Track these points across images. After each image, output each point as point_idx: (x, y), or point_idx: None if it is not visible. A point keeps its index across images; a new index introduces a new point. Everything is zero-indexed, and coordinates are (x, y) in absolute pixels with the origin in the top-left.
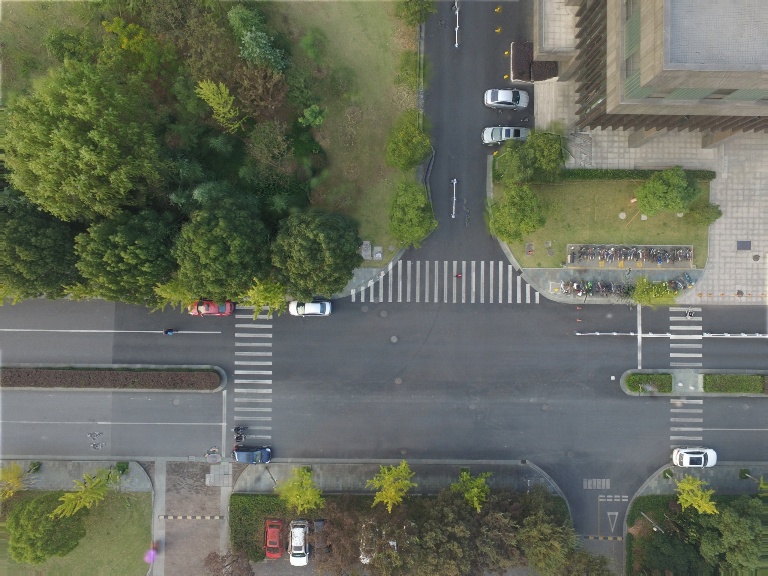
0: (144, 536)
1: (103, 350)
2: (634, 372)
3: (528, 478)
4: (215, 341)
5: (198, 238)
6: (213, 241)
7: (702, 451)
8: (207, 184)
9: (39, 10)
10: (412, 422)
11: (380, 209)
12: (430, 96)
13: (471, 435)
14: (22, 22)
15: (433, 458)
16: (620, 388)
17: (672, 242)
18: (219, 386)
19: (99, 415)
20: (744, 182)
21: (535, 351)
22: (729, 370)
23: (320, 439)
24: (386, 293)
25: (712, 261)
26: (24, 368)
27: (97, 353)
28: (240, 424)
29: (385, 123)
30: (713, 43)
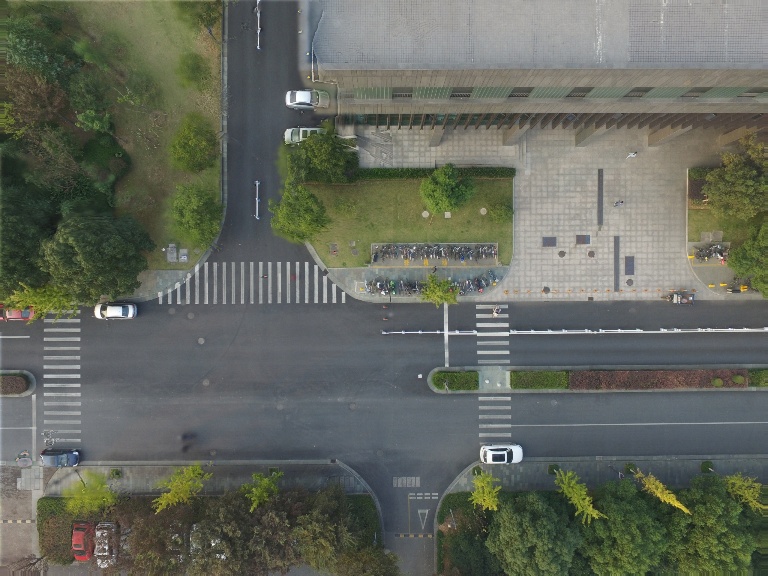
0: None
1: None
2: (440, 370)
3: (333, 477)
4: (23, 346)
5: None
6: None
7: (505, 448)
8: None
9: None
10: (221, 423)
11: None
12: (234, 98)
13: (280, 435)
14: None
15: (242, 459)
16: (428, 386)
17: (477, 240)
18: (26, 390)
19: None
20: (547, 178)
21: (342, 351)
22: (534, 367)
23: (130, 442)
24: (193, 295)
25: (518, 258)
26: None
27: None
28: (50, 428)
29: None
30: (353, 42)
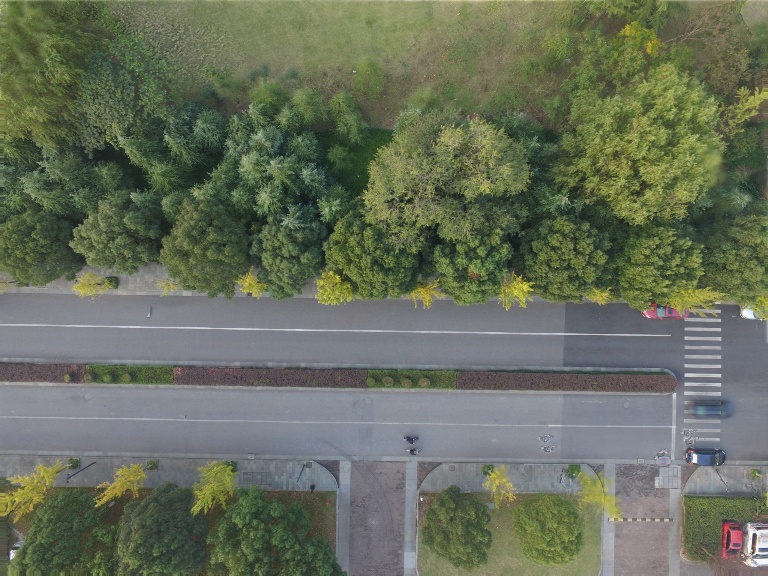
0: (594, 539)
1: (554, 353)
2: None
3: None
4: (666, 344)
5: None
6: None
7: None
8: None
9: (489, 13)
10: None
11: None
12: None
13: None
14: (470, 24)
15: None
16: None
17: None
18: None
19: (550, 418)
20: None
21: None
22: None
23: (767, 441)
24: None
25: None
26: (483, 371)
27: (549, 356)
28: (689, 427)
29: None
30: None
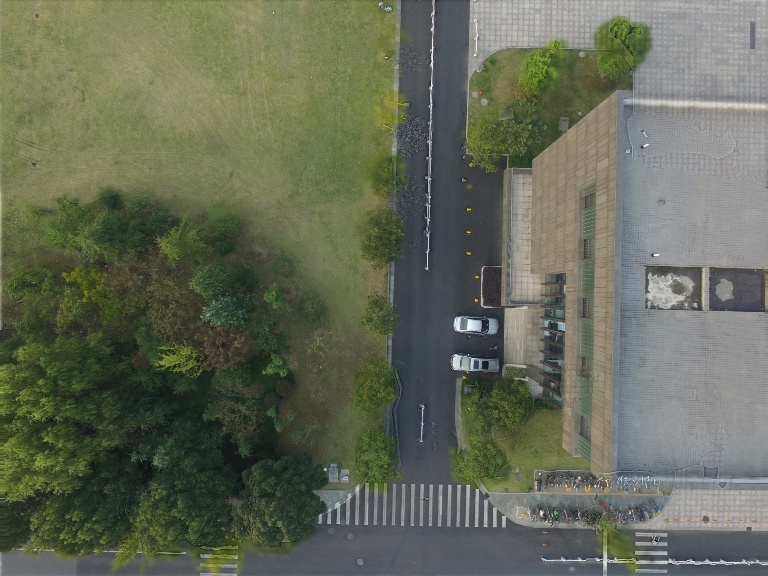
0: None
1: (67, 569)
2: None
3: None
4: (180, 562)
5: (156, 519)
6: (171, 522)
7: None
8: (170, 435)
9: (5, 224)
10: None
11: (348, 432)
12: (400, 318)
13: None
14: None
15: None
16: None
17: None
18: None
19: None
20: None
21: (501, 575)
22: None
23: None
24: (353, 515)
25: (679, 487)
26: None
27: (61, 572)
28: None
29: (354, 347)
30: (660, 456)
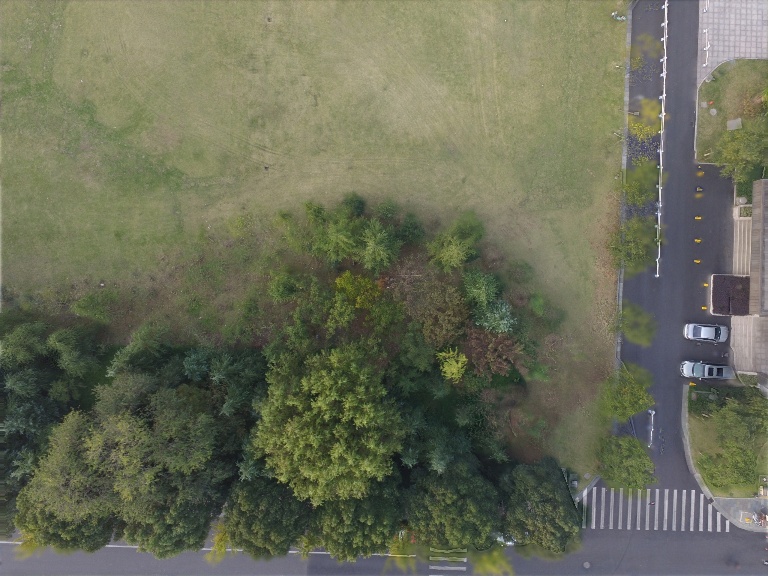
0: None
1: (298, 571)
2: None
3: None
4: (410, 564)
5: (449, 523)
6: (464, 526)
7: None
8: (433, 439)
9: (239, 228)
10: None
11: (577, 437)
12: (629, 325)
13: None
14: (221, 238)
15: None
16: None
17: None
18: None
19: None
20: None
21: None
22: None
23: None
24: None
25: None
26: None
27: (292, 574)
28: None
29: (585, 353)
30: None
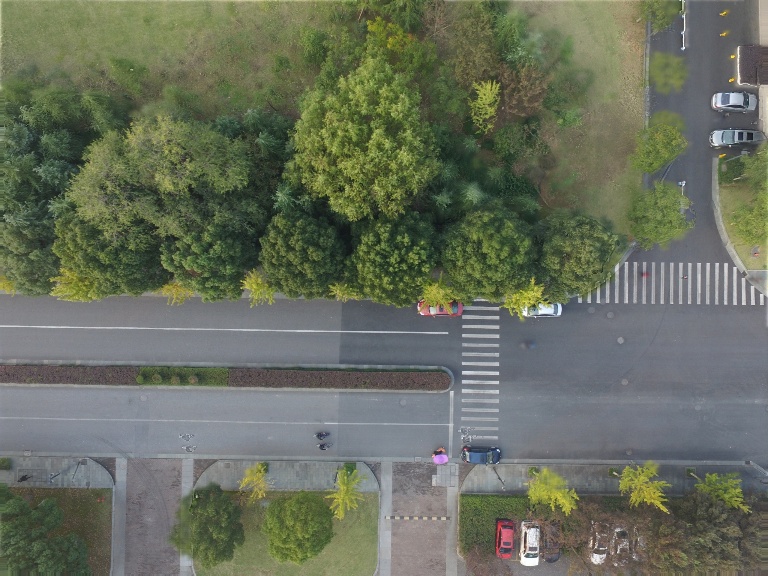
0: (371, 537)
1: (330, 350)
2: None
3: (758, 479)
4: (443, 342)
5: (487, 239)
6: (502, 242)
7: None
8: (466, 185)
9: None
10: (638, 423)
11: (607, 211)
12: (656, 99)
13: (696, 436)
14: (248, 22)
15: (659, 459)
16: None
17: None
18: (448, 387)
19: (326, 415)
20: None
21: (760, 352)
22: None
23: (547, 440)
24: (613, 294)
25: None
26: (255, 368)
27: (324, 353)
28: (467, 425)
29: (614, 125)
30: None
